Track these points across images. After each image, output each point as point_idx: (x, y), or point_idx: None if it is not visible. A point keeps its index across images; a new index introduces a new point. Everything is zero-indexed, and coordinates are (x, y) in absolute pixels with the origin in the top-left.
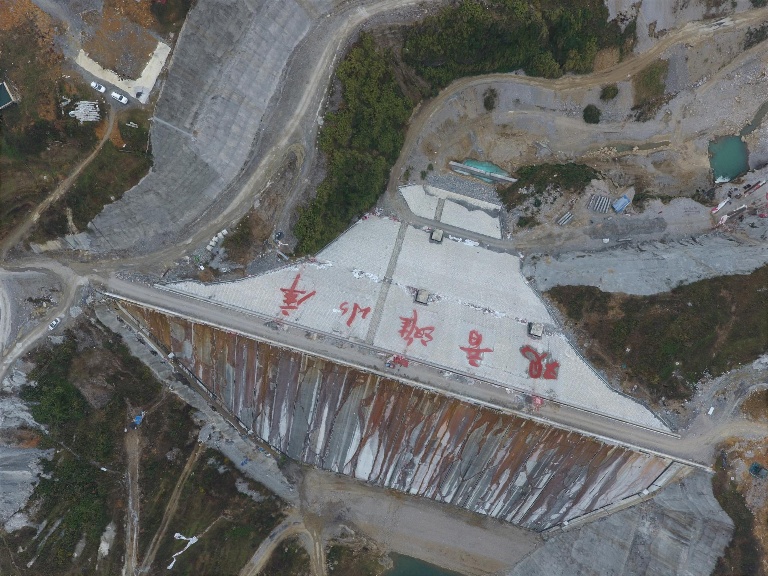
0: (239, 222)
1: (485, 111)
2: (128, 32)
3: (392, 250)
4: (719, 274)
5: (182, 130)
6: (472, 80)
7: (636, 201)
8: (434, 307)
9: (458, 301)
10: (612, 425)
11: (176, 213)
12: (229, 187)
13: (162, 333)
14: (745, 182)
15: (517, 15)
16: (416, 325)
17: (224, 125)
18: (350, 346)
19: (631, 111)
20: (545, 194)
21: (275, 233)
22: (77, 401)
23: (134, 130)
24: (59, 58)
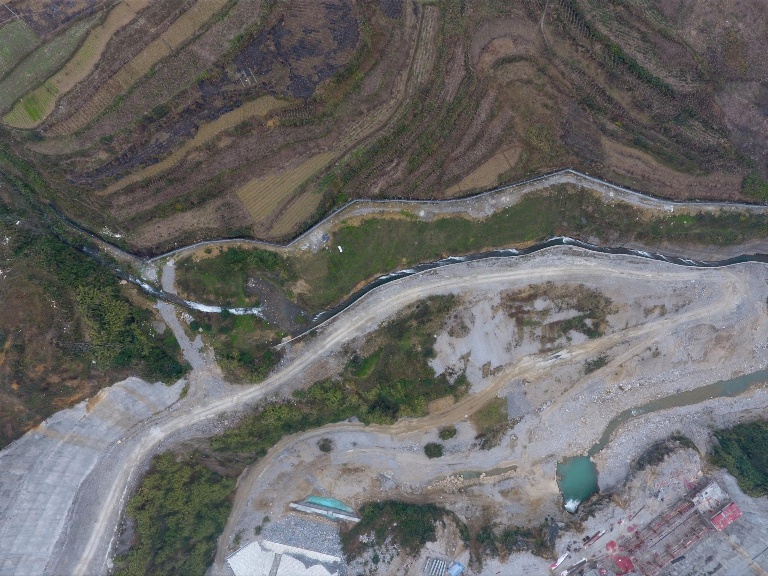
0: None
1: (323, 453)
2: None
3: None
4: None
5: None
6: (303, 433)
7: (480, 544)
8: None
9: None
10: None
11: None
12: None
13: None
14: (584, 533)
15: (328, 406)
16: None
17: None
18: None
19: (475, 440)
20: (383, 549)
21: None
22: None
23: None
24: None
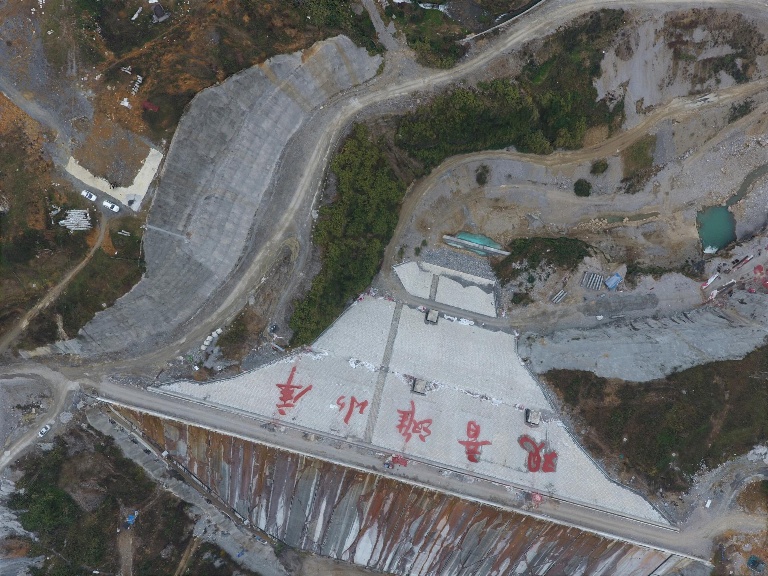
0: (234, 319)
1: (477, 186)
2: (119, 139)
3: (388, 334)
4: (712, 360)
5: (175, 233)
6: (464, 157)
7: (628, 274)
8: (431, 396)
9: (455, 388)
10: (611, 520)
11: (169, 314)
12: (223, 284)
13: (156, 433)
14: (733, 257)
15: (508, 101)
16: (414, 418)
17: (218, 224)
18: (348, 446)
19: (620, 183)
20: (538, 270)
21: (270, 326)
22: (68, 507)
23: (126, 238)
24: (48, 166)
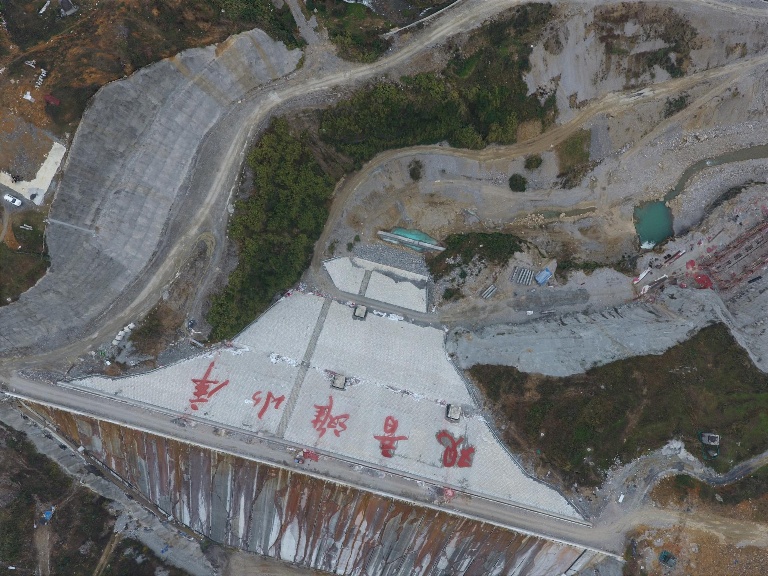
0: (147, 314)
1: (412, 181)
2: (22, 132)
3: (313, 330)
4: (632, 354)
5: (82, 228)
6: (396, 152)
7: (562, 269)
8: (351, 392)
9: (377, 384)
10: (524, 515)
11: (80, 309)
12: (137, 278)
13: (69, 428)
14: (665, 252)
15: (432, 95)
16: (330, 413)
17: (129, 218)
18: (259, 441)
19: (557, 179)
20: (471, 265)
21: (188, 321)
22: None
23: (28, 232)
24: None
